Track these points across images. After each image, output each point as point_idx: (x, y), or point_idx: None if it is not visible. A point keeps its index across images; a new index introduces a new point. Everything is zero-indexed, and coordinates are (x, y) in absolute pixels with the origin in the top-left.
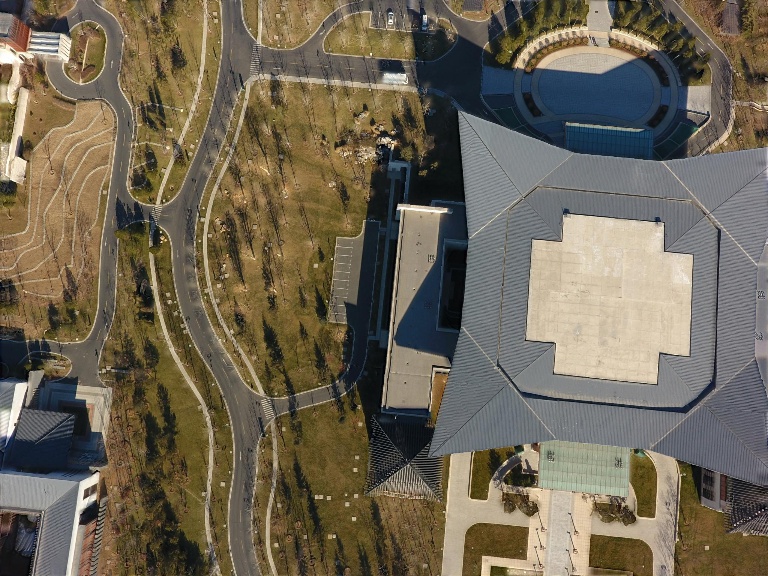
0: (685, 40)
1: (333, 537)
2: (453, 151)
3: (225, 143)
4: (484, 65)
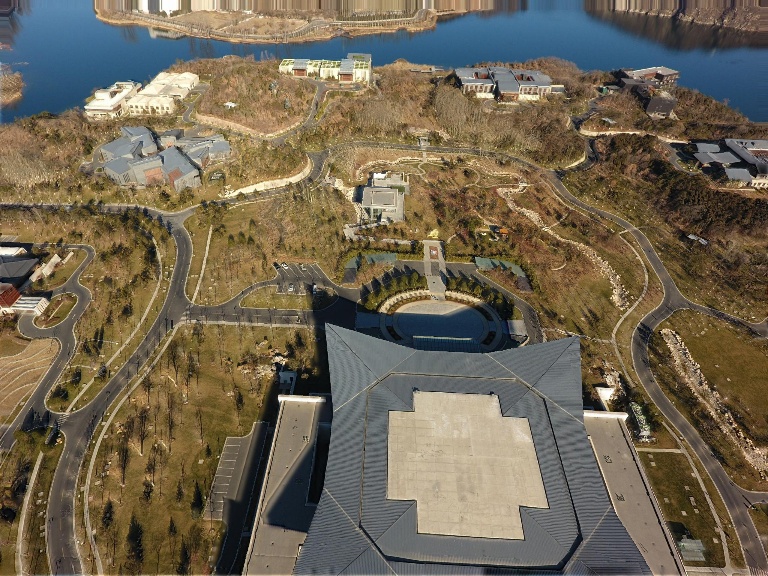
0: (495, 294)
1: None
2: None
3: (145, 365)
4: (357, 312)
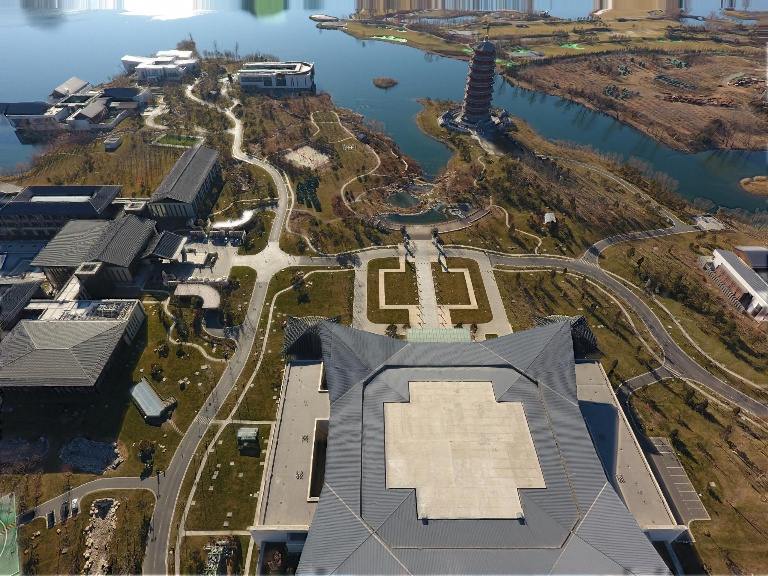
0: None
1: (579, 309)
2: None
3: None
4: None
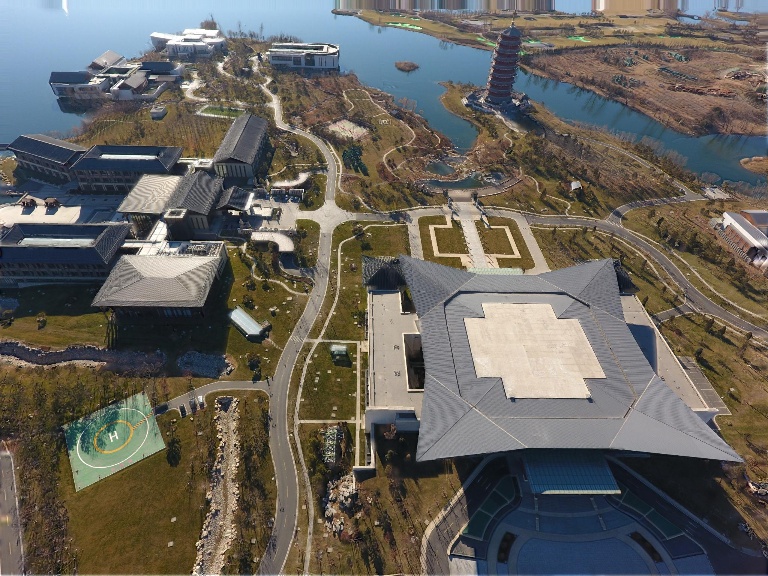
0: None
1: None
2: (694, 484)
3: None
4: None
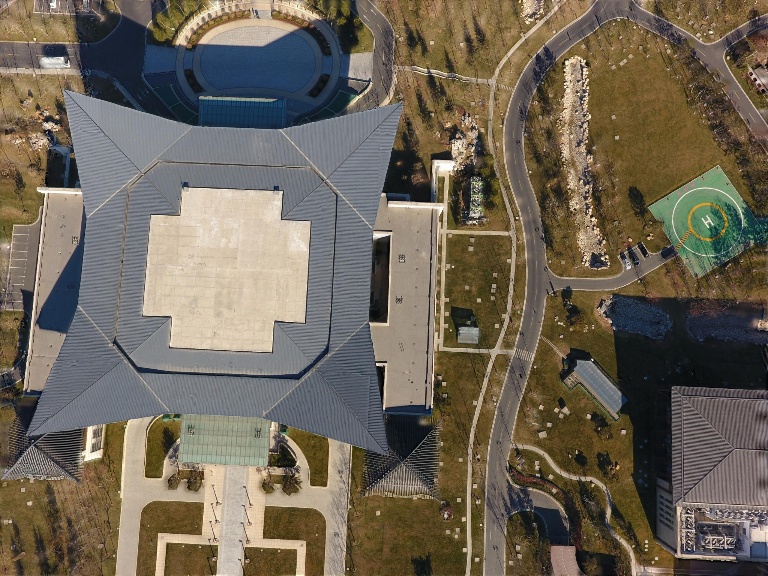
0: None
1: (9, 523)
2: None
3: None
4: (147, 44)
